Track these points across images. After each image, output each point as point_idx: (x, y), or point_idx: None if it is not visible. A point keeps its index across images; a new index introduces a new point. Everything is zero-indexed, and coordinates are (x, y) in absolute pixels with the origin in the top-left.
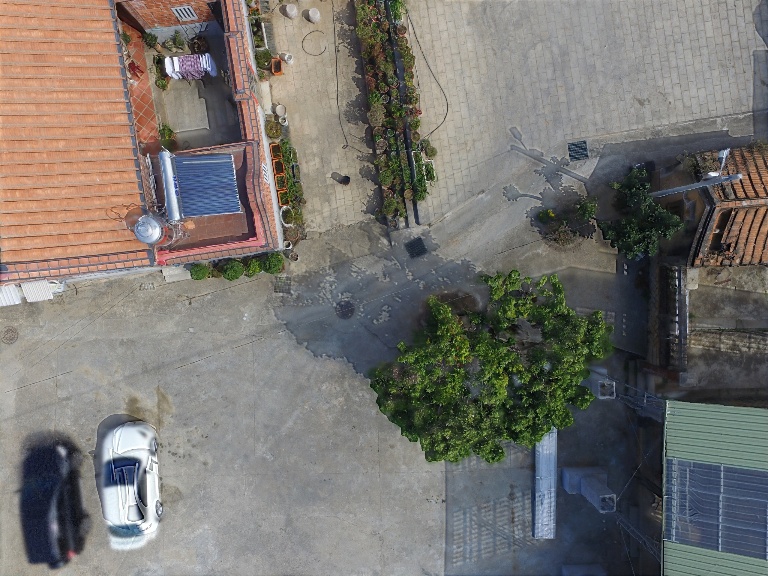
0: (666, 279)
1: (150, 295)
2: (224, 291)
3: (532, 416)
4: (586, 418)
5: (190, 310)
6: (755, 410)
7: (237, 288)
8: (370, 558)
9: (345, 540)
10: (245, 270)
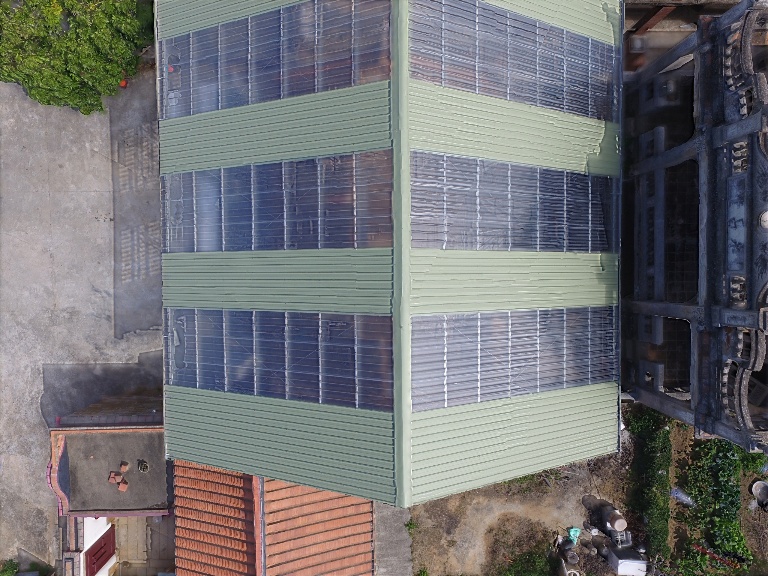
0: None
1: None
2: None
3: (75, 37)
4: None
5: None
6: None
7: None
8: (41, 274)
9: (17, 257)
10: None
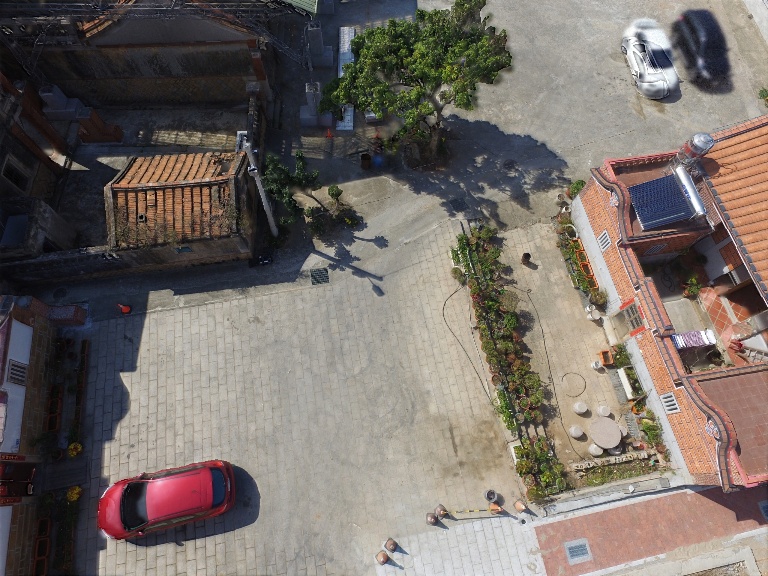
0: None
1: None
2: None
3: None
4: None
5: None
6: None
7: None
8: None
9: None
10: None
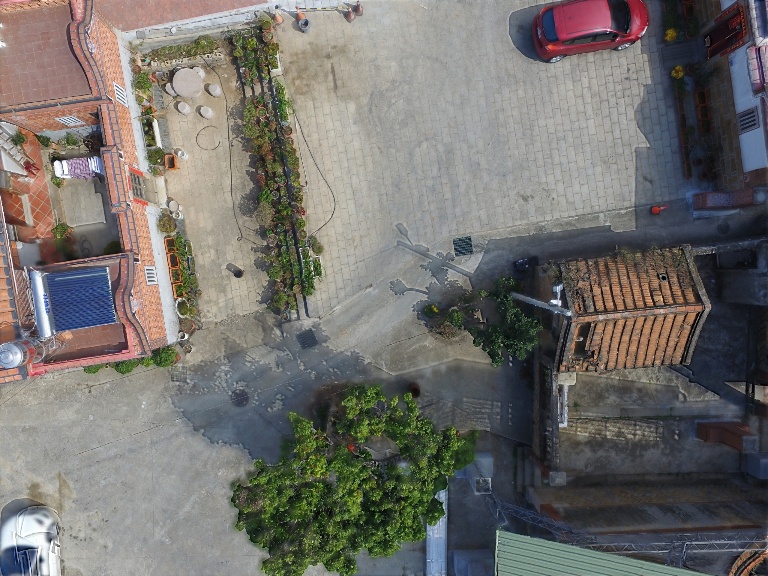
0: (543, 376)
1: (51, 383)
2: (122, 380)
3: (383, 533)
4: (477, 502)
5: (90, 398)
6: (572, 548)
7: (135, 377)
8: None
9: None
10: (139, 362)
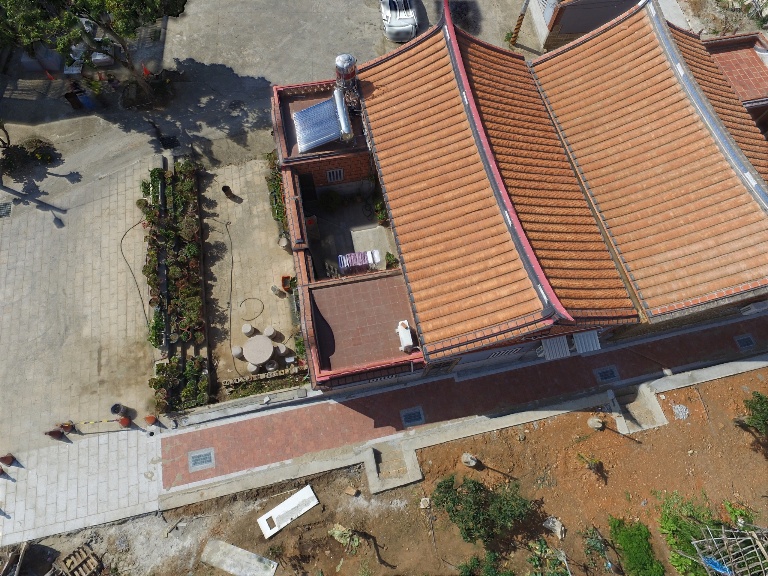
0: None
1: None
2: None
3: None
4: None
5: None
6: None
7: None
8: None
9: None
10: None
